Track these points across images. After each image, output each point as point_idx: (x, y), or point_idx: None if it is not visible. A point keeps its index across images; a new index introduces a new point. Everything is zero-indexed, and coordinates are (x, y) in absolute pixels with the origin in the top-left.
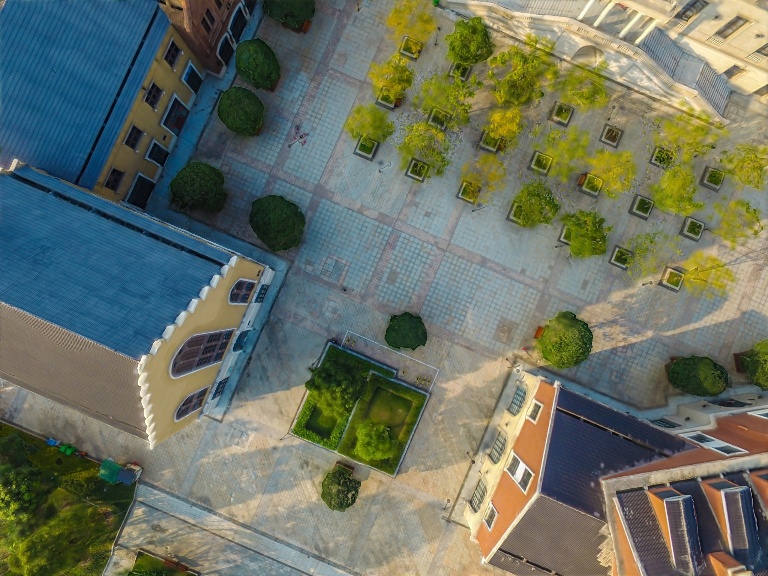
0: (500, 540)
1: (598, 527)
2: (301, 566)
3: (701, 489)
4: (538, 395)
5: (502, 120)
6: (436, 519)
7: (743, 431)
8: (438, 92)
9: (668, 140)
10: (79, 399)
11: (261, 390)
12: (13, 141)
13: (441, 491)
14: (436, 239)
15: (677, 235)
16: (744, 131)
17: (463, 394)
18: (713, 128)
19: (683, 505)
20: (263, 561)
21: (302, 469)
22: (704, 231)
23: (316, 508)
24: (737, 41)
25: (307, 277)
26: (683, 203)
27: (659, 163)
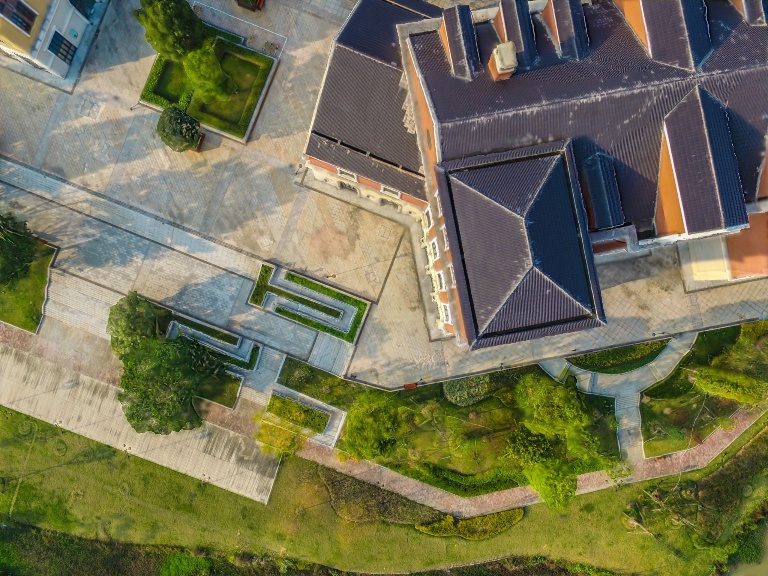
0: None
1: (397, 79)
2: (158, 237)
3: (492, 27)
4: None
5: None
6: (289, 184)
7: None
8: None
9: None
10: None
11: (110, 62)
12: None
13: (293, 157)
14: None
15: None
16: None
17: (312, 61)
18: None
19: (458, 9)
20: (121, 235)
21: (154, 138)
22: None
23: (169, 176)
24: None
25: None
26: None
27: None
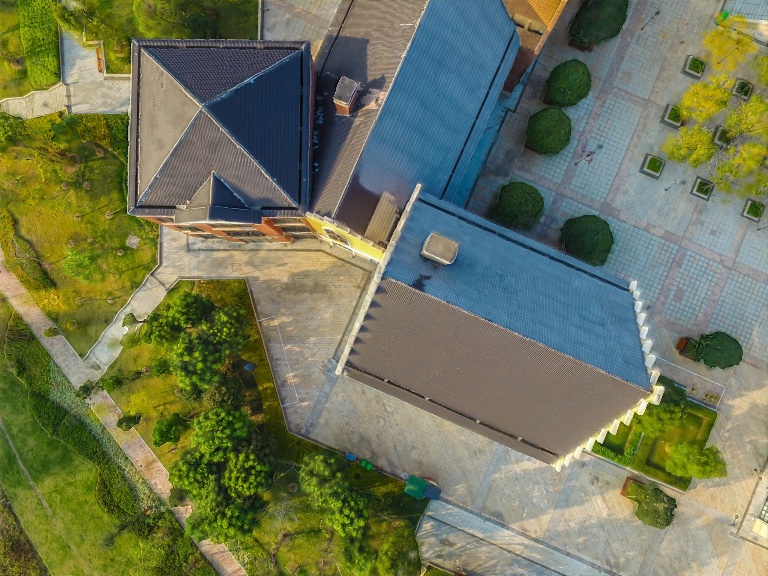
0: None
1: None
2: None
3: None
4: None
5: None
6: (724, 535)
7: None
8: (721, 111)
9: None
10: (500, 423)
11: None
12: (403, 165)
13: (729, 507)
14: (722, 257)
15: None
16: None
17: (750, 411)
18: None
19: None
20: (550, 575)
21: (592, 485)
22: None
23: (607, 523)
24: None
25: None
26: None
27: None
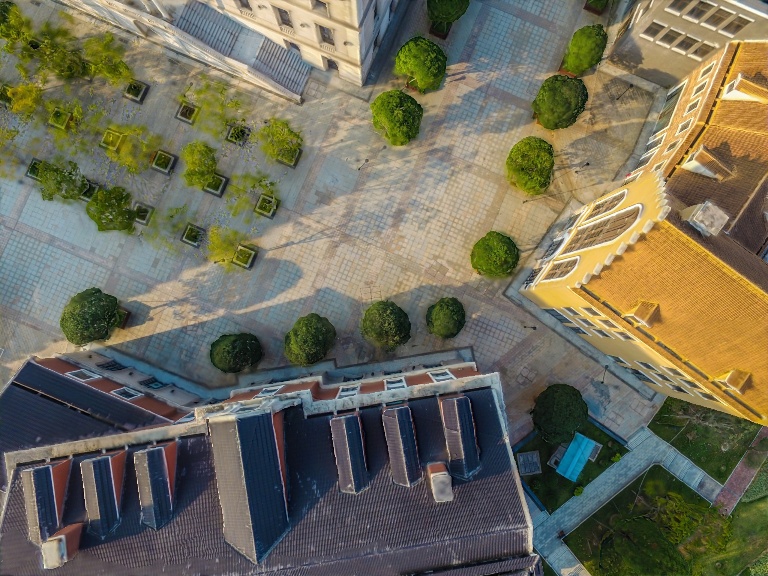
0: None
1: None
2: None
3: None
4: None
5: (17, 94)
6: None
7: None
8: (11, 70)
9: (246, 117)
10: None
11: None
12: None
13: None
14: (4, 218)
15: (252, 212)
16: (324, 107)
17: None
18: (292, 104)
19: (33, 475)
20: None
21: None
22: (279, 208)
23: None
24: (258, 13)
25: None
26: (194, 177)
27: (235, 140)
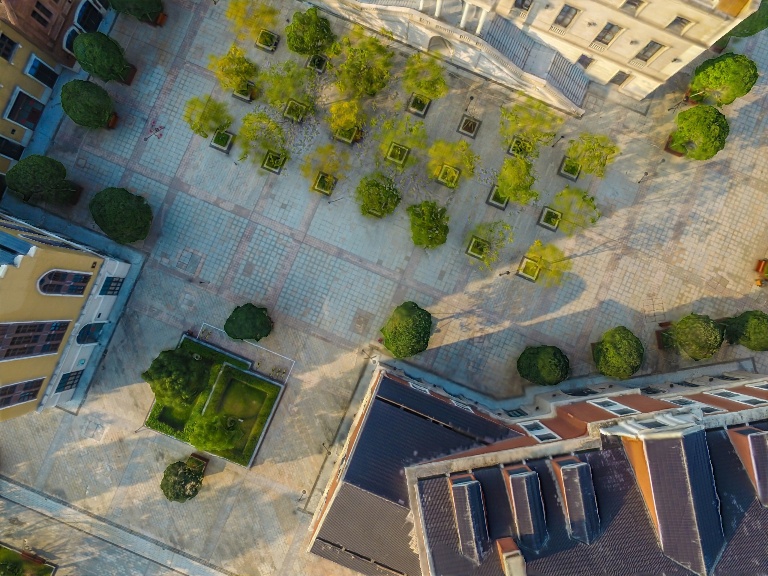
0: (317, 529)
1: (404, 514)
2: (158, 558)
3: (502, 475)
4: (373, 385)
5: (340, 110)
6: (292, 510)
7: (570, 419)
8: (295, 84)
9: (526, 130)
10: None
11: (116, 383)
12: None
13: (297, 482)
14: (292, 231)
15: (535, 225)
16: (603, 121)
17: (319, 385)
18: (571, 118)
19: (468, 491)
20: (121, 553)
21: (157, 461)
22: (562, 221)
23: None
24: (575, 30)
25: (163, 270)
26: (519, 192)
27: (517, 153)
